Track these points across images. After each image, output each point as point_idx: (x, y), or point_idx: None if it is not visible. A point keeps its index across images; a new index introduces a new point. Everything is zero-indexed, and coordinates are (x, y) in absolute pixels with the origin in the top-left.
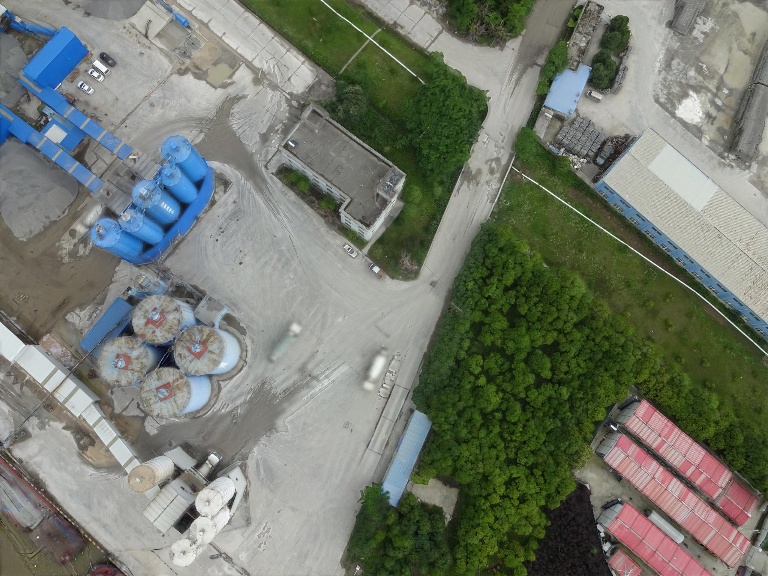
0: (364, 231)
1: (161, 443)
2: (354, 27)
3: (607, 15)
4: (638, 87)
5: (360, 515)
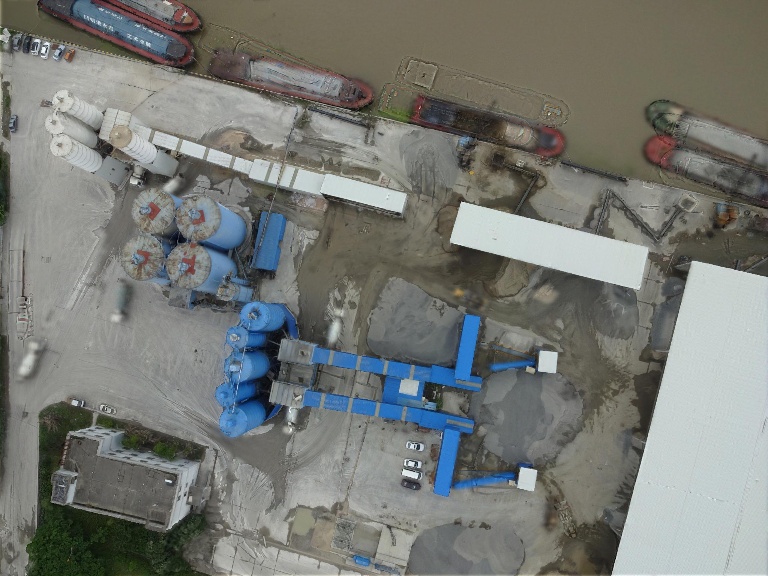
0: (82, 431)
1: (189, 173)
2: None
3: None
4: None
5: (0, 196)
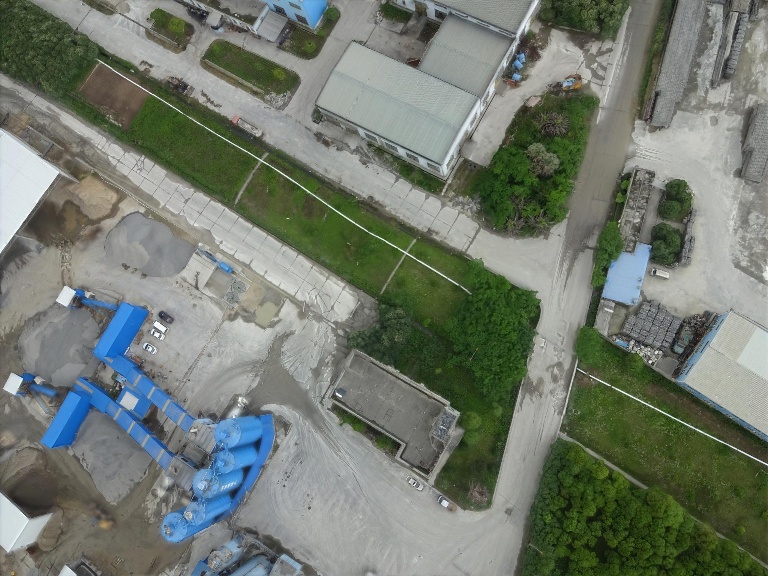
0: None
1: None
2: (388, 244)
3: (660, 181)
4: (711, 253)
5: None
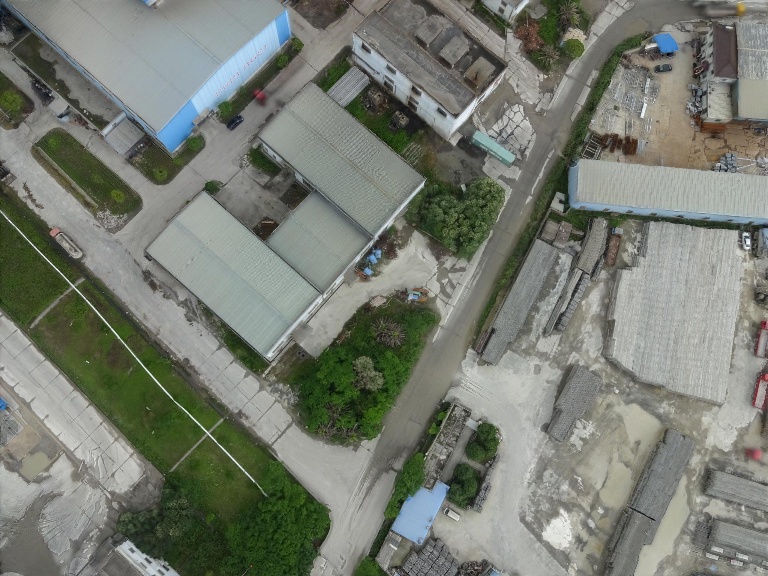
0: None
1: None
2: (192, 419)
3: (474, 421)
4: (503, 502)
5: None
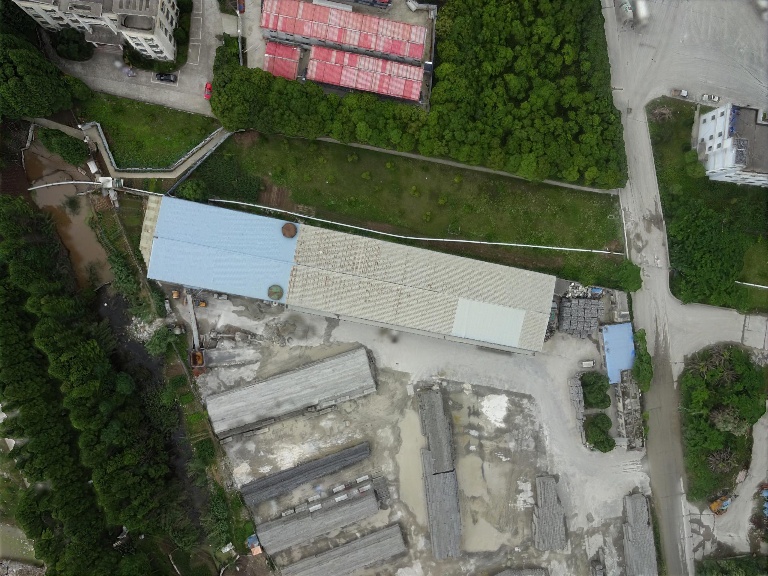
0: None
1: None
2: None
3: None
4: (553, 399)
5: None
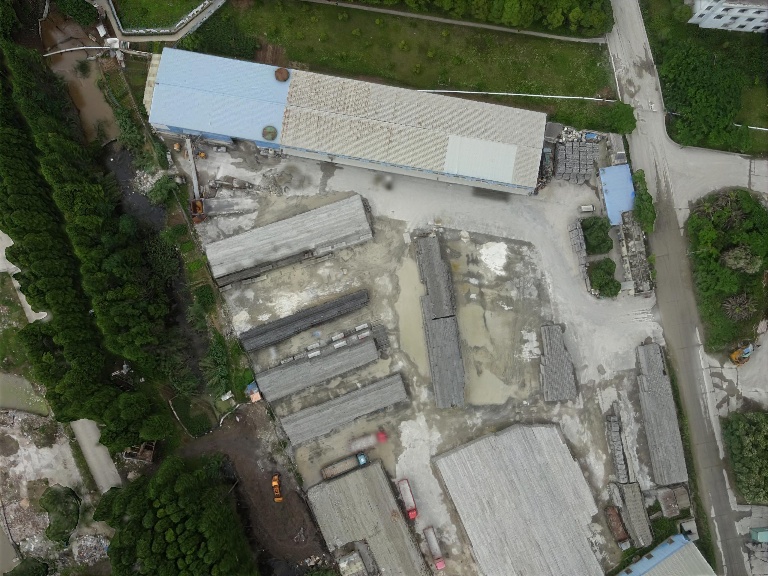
0: None
1: None
2: None
3: (627, 289)
4: (553, 246)
5: None
